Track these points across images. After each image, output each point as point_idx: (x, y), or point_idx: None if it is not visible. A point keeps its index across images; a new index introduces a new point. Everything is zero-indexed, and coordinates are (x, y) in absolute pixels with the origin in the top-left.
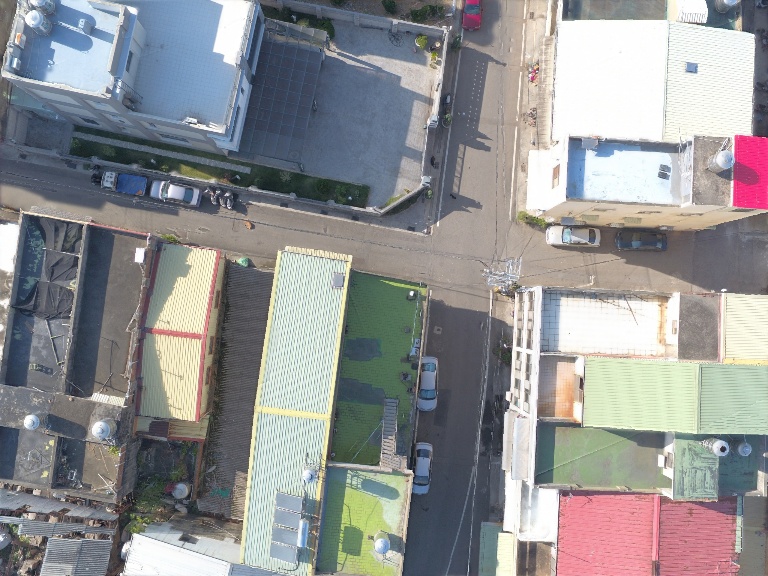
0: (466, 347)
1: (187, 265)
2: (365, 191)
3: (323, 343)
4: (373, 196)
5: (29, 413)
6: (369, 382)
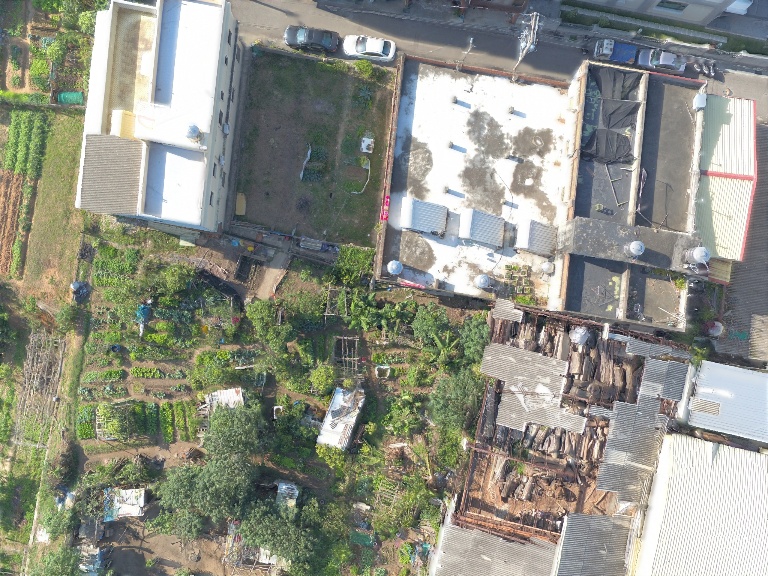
0: None
1: (728, 114)
2: None
3: None
4: None
5: (617, 244)
6: None
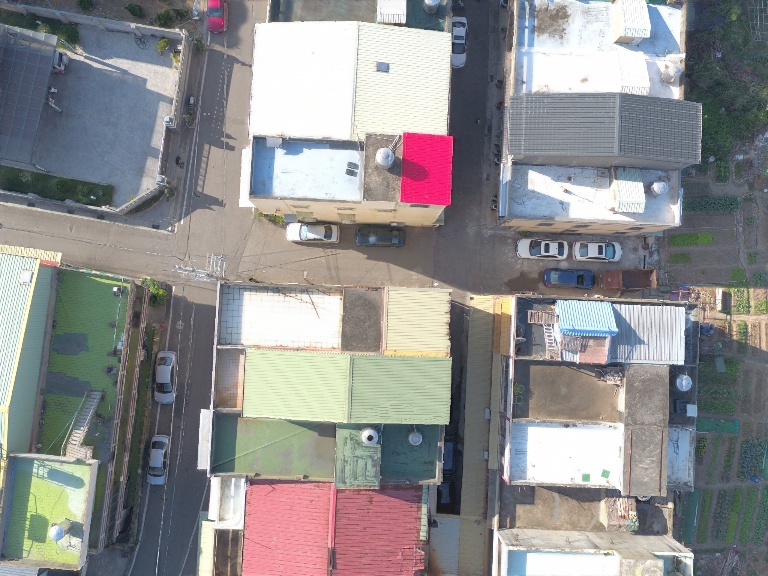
0: (207, 342)
1: None
2: (108, 190)
3: (7, 337)
4: (118, 195)
5: None
6: (76, 375)
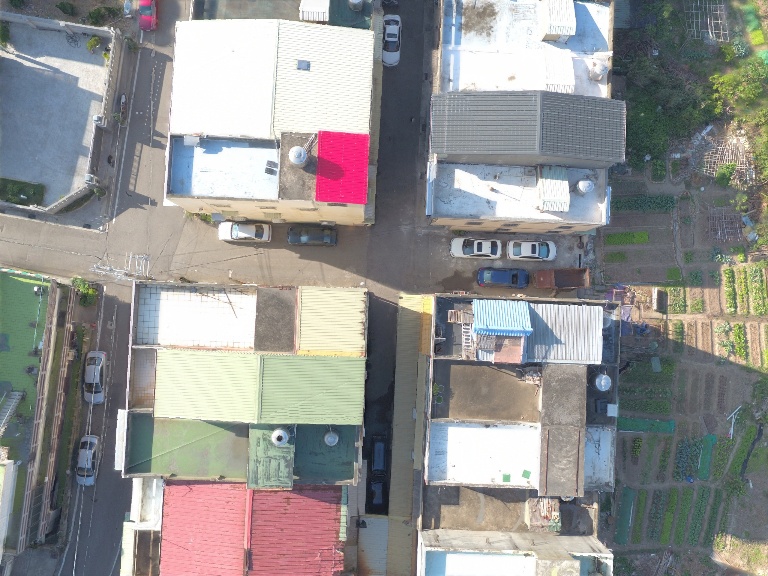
0: None
1: None
2: (38, 190)
3: None
4: (49, 194)
5: None
6: None
